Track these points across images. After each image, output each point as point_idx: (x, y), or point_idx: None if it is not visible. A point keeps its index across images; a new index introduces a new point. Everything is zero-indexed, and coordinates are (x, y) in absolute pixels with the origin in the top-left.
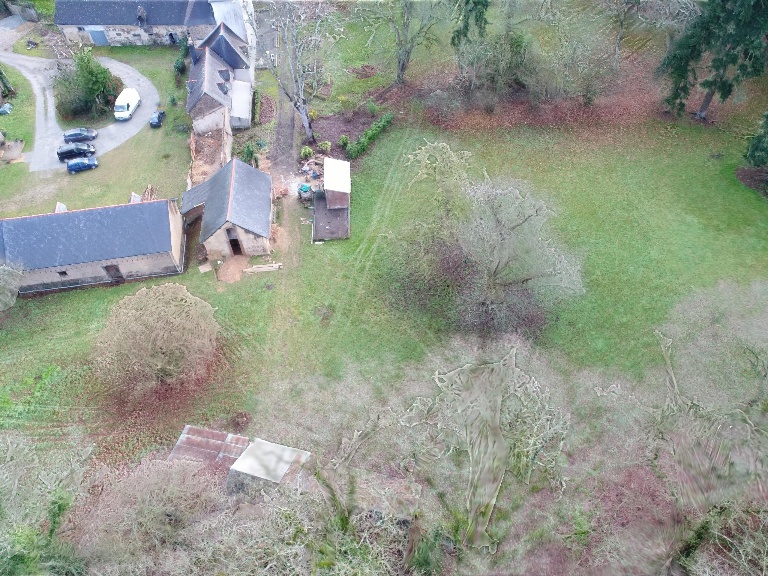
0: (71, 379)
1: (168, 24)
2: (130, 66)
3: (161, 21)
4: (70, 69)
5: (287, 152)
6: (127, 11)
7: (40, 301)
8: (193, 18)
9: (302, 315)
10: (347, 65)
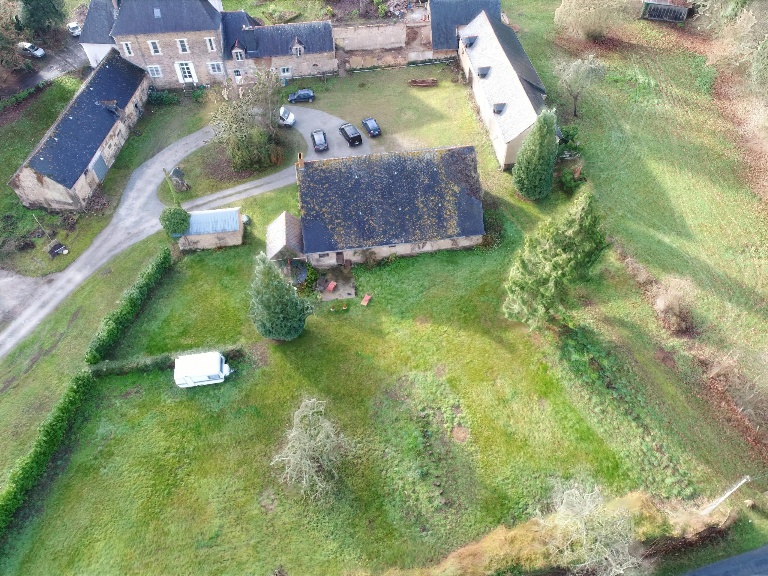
0: (614, 68)
1: (132, 94)
2: (170, 145)
3: (125, 97)
4: (275, 90)
5: (373, 24)
6: (95, 115)
7: (548, 103)
8: (213, 20)
9: (544, 1)
10: (249, 6)
